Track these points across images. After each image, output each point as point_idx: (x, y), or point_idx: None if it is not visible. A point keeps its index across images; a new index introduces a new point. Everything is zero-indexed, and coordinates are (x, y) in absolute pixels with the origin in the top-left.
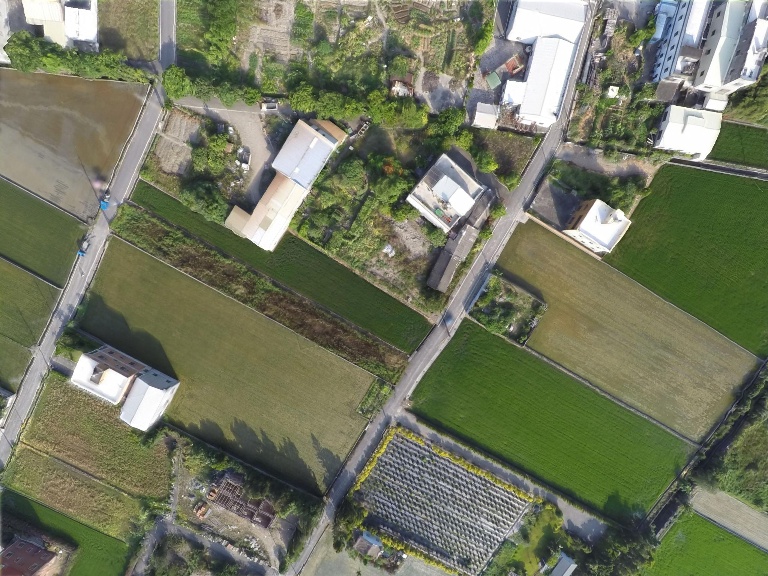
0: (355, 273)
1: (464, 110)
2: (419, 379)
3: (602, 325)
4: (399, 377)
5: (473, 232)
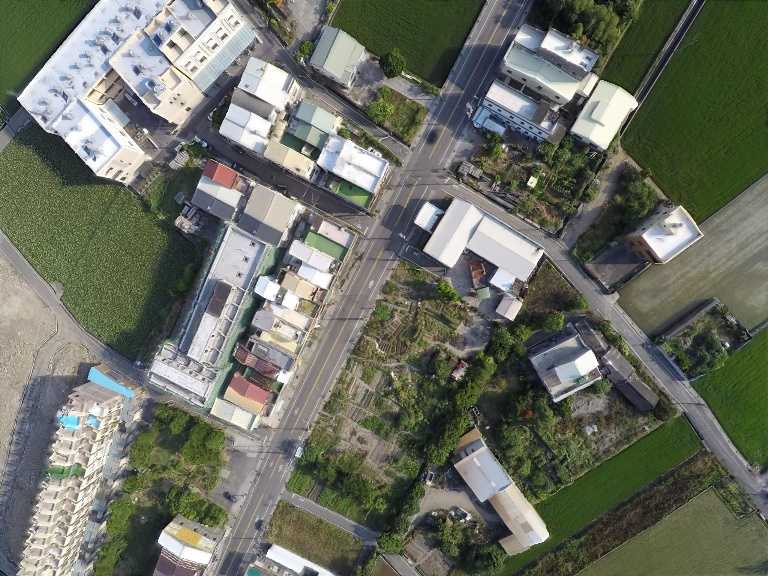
0: (598, 466)
1: (498, 326)
2: (734, 449)
3: (766, 245)
4: (723, 467)
5: (612, 353)
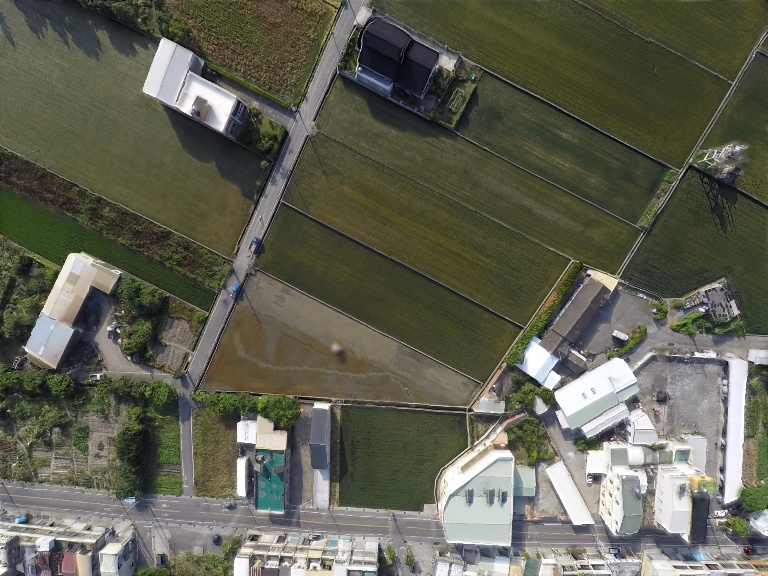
0: (2, 235)
1: None
2: None
3: None
4: None
5: None
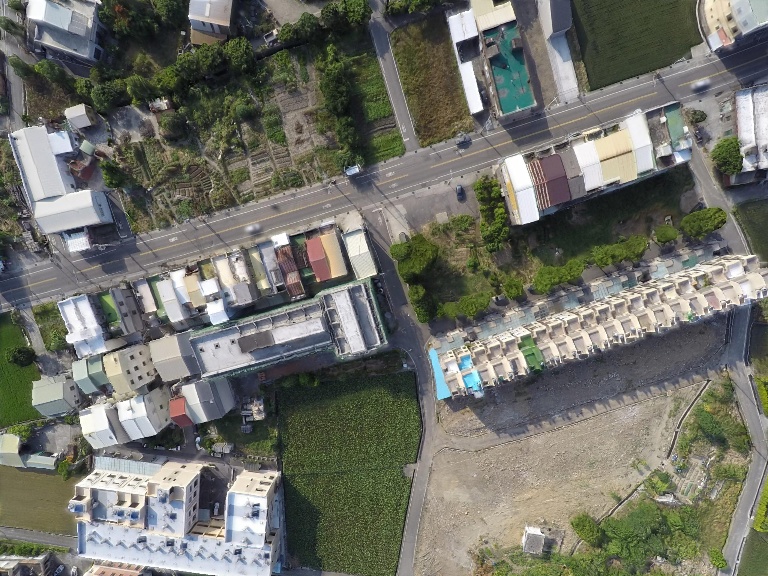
0: None
1: (97, 111)
2: None
3: None
4: None
5: None
